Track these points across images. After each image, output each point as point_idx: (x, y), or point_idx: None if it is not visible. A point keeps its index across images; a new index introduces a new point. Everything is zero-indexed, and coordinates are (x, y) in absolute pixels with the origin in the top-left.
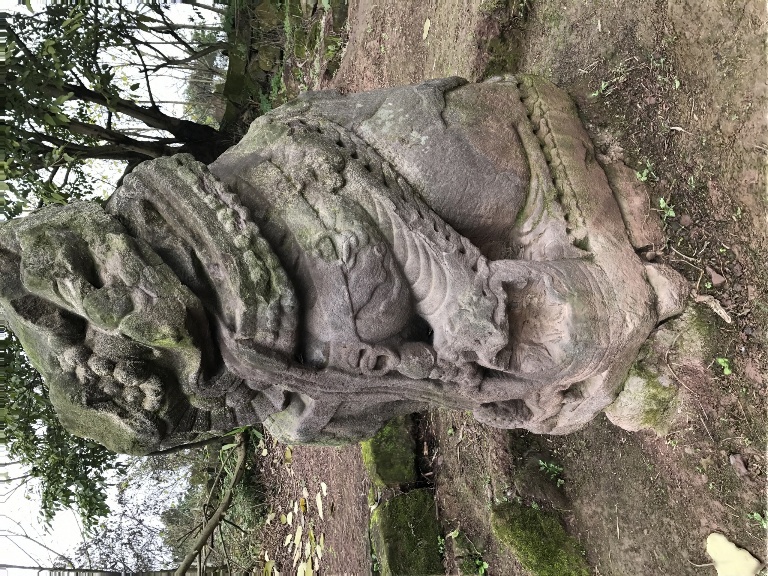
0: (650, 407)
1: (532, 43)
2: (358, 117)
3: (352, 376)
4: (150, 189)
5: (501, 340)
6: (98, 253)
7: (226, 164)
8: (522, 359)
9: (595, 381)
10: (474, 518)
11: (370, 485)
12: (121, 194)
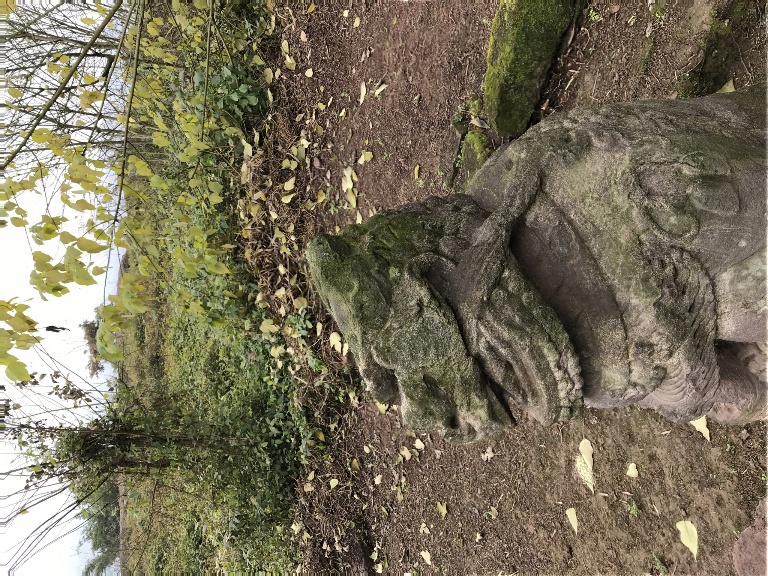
0: None
1: None
2: (730, 262)
3: None
4: (516, 361)
5: None
6: (464, 414)
7: (579, 281)
8: None
9: None
10: None
11: (478, 96)
12: (482, 329)
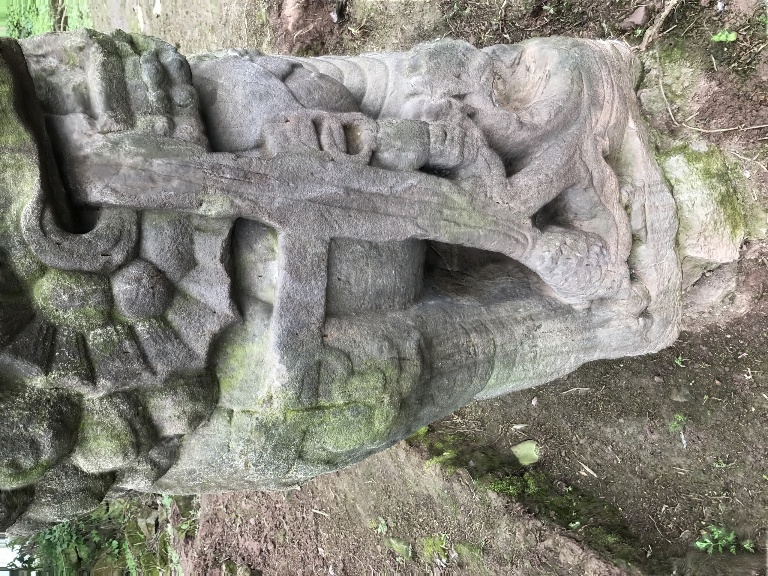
0: (717, 191)
1: None
2: None
3: (320, 159)
4: None
5: (483, 55)
6: None
7: None
8: (529, 118)
9: (631, 150)
10: None
11: None
12: None
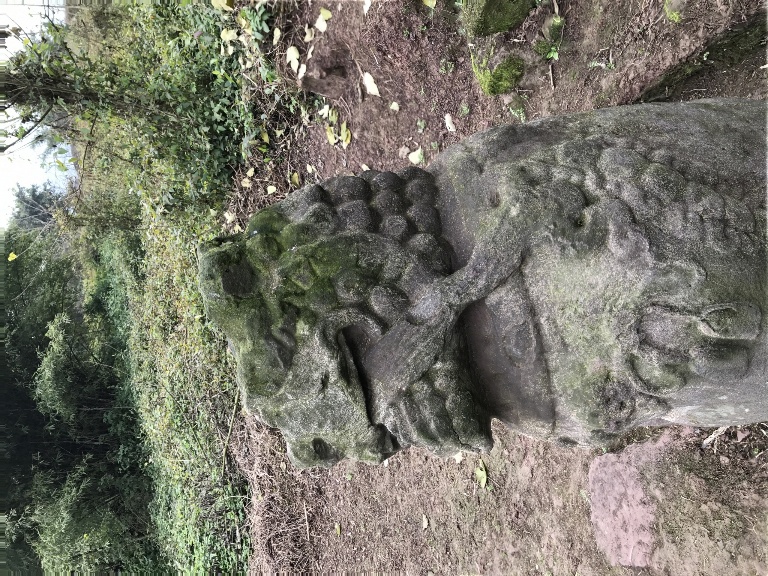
0: None
1: None
2: None
3: None
4: None
5: None
6: None
7: (521, 386)
8: None
9: None
10: (582, 29)
11: None
12: (392, 414)
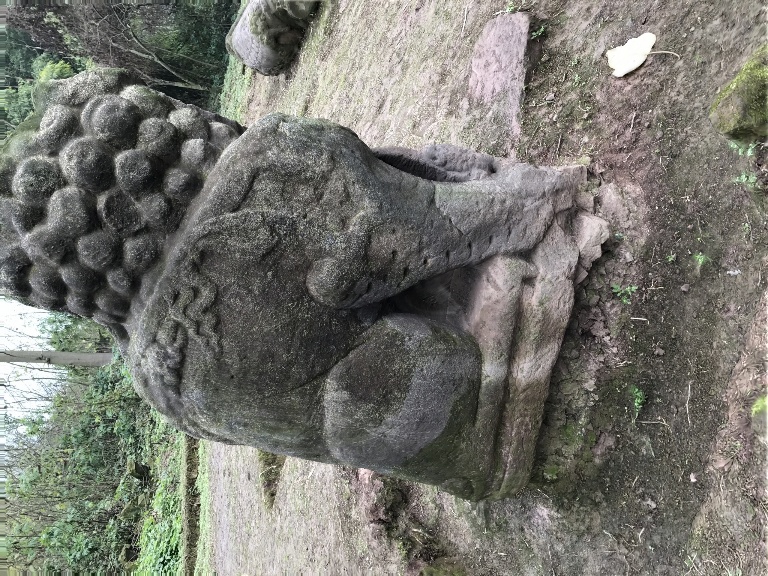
0: None
1: (450, 533)
2: None
3: None
4: None
5: None
6: None
7: None
8: None
9: None
10: None
11: None
12: None
